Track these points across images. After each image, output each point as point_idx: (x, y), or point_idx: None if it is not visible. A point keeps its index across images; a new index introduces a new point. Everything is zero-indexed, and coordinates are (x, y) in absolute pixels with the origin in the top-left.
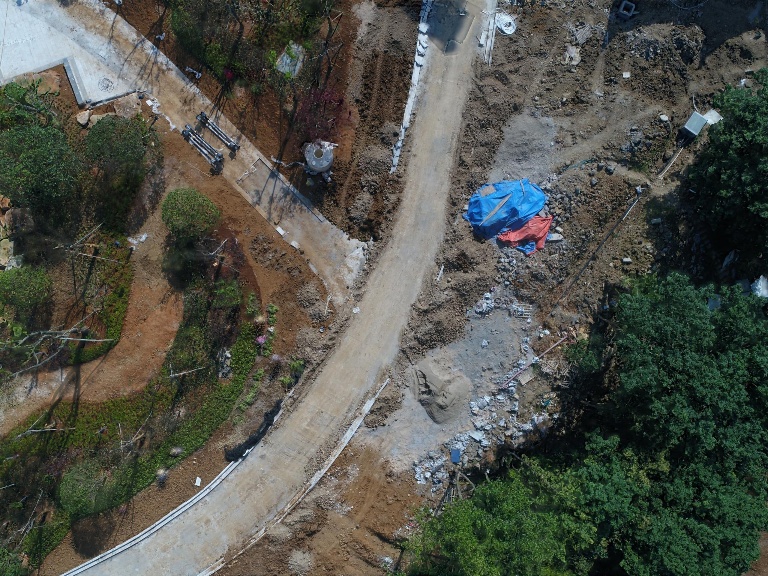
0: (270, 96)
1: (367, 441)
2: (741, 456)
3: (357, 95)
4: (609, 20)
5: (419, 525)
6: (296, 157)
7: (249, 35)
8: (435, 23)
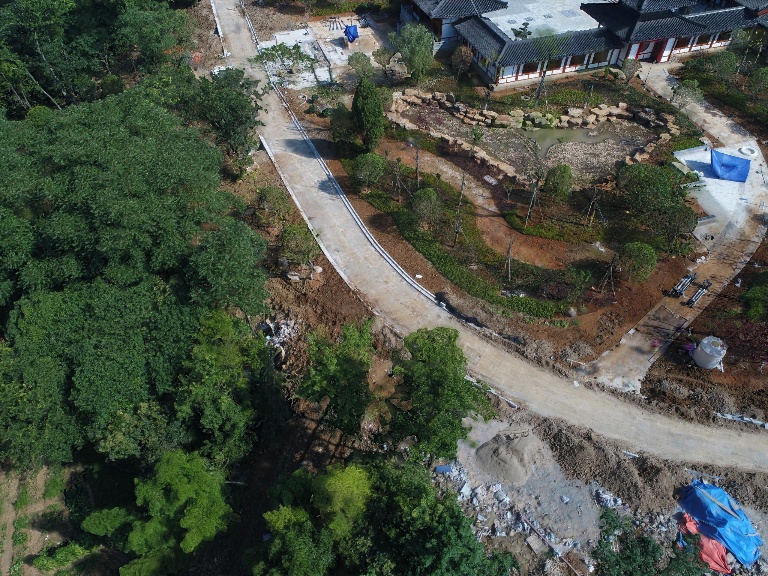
0: None
1: None
2: None
3: None
4: None
5: (370, 439)
6: None
7: None
8: None
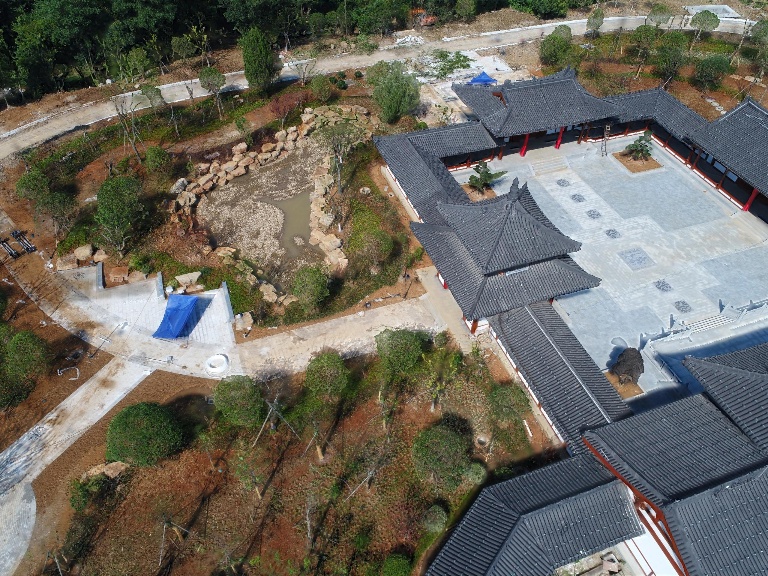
0: None
1: (6, 132)
2: None
3: None
4: None
5: None
6: None
7: None
8: None
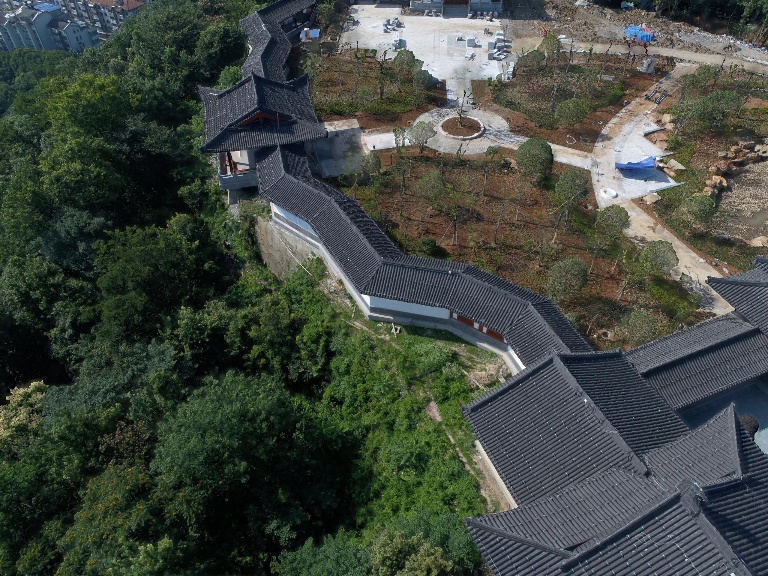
0: None
1: None
2: None
3: None
4: None
5: None
6: None
7: (601, 84)
8: None
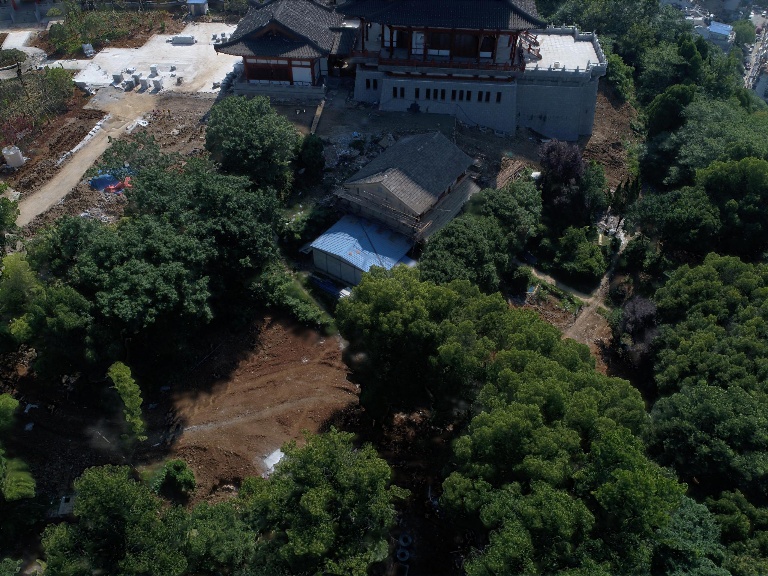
0: (3, 143)
1: None
2: (172, 209)
3: (51, 143)
4: (200, 124)
5: None
6: (3, 162)
7: None
8: (107, 124)
